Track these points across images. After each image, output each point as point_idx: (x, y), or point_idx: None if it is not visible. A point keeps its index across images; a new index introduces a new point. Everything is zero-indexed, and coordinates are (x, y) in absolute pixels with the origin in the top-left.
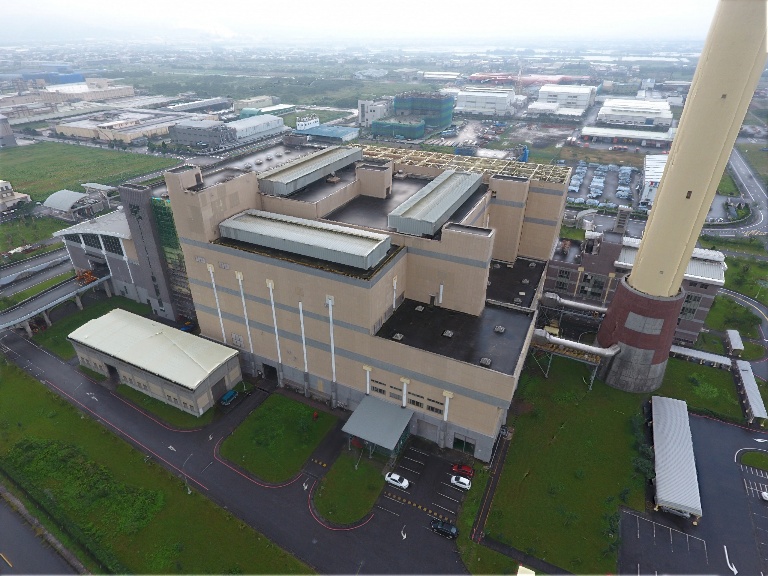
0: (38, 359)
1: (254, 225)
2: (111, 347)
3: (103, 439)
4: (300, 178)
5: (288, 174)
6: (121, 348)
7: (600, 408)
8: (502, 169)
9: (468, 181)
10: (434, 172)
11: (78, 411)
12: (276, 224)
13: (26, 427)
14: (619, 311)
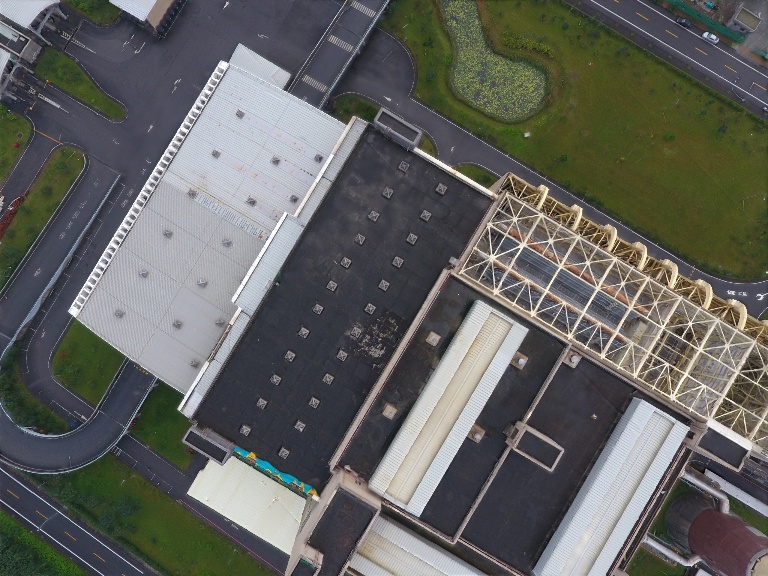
0: (157, 468)
1: (385, 573)
2: (237, 518)
3: (262, 575)
4: (436, 486)
5: (418, 463)
6: (248, 521)
7: (651, 570)
8: (728, 390)
9: (661, 462)
10: (624, 374)
11: (229, 545)
12: (408, 559)
13: (197, 561)
14: (724, 567)
